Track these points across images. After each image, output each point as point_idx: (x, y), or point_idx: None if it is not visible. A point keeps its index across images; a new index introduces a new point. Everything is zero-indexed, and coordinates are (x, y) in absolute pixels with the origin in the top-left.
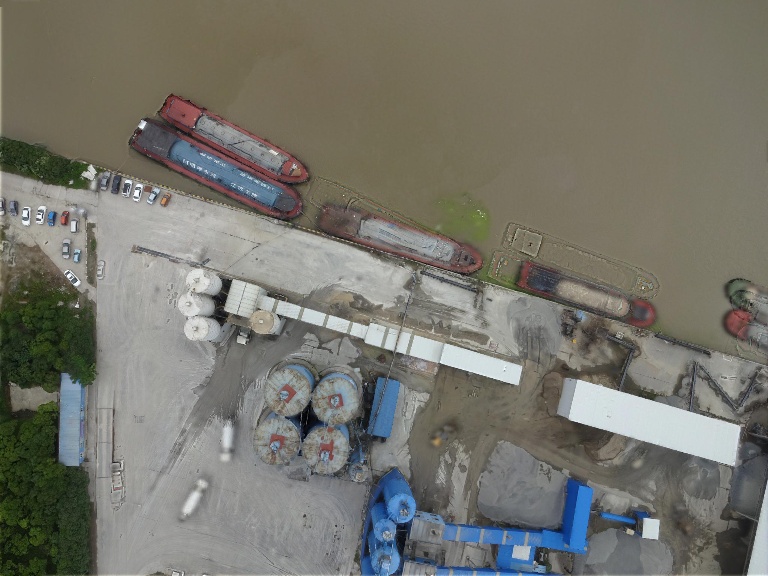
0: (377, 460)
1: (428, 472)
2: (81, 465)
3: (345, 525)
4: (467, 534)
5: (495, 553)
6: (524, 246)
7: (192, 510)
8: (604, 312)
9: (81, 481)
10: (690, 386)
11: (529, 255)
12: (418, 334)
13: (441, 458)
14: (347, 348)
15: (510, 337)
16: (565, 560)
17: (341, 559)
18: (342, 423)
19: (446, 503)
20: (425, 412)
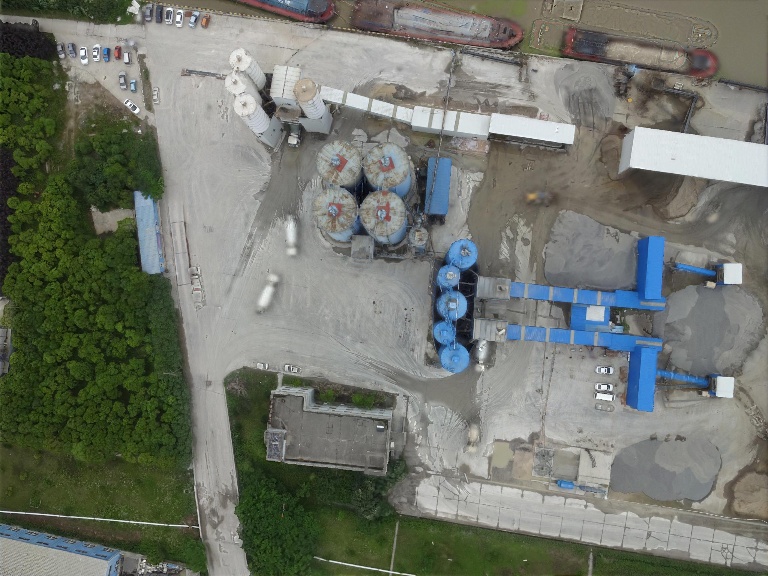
0: (438, 243)
1: (491, 249)
2: (163, 275)
3: (414, 308)
4: (535, 291)
5: (568, 321)
6: (565, 11)
7: (268, 307)
8: (659, 66)
9: (164, 286)
10: (763, 127)
11: (571, 20)
12: None
13: (502, 234)
14: (395, 138)
15: (560, 106)
16: (643, 322)
17: (414, 340)
18: (395, 186)
19: (512, 277)
20: (481, 191)
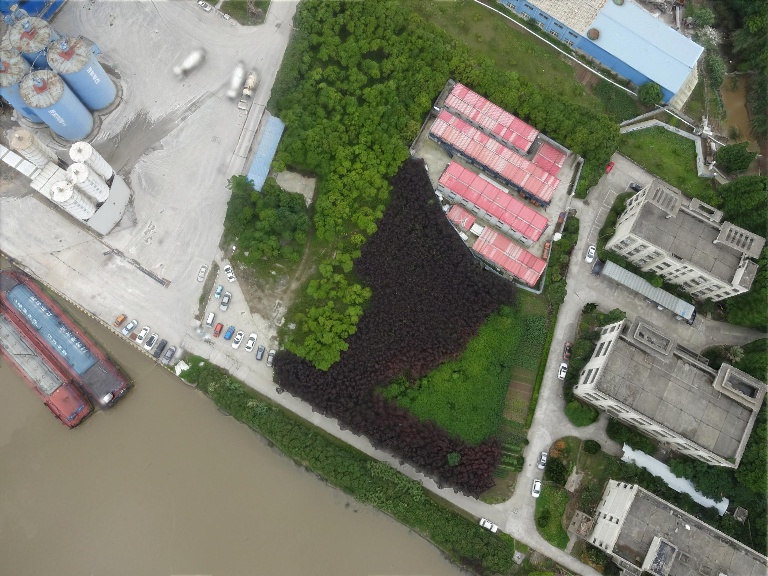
0: None
1: None
2: None
3: (82, 7)
4: None
5: None
6: None
7: (200, 59)
8: None
9: None
10: None
11: None
12: None
13: None
14: None
15: None
16: None
17: None
18: (7, 51)
19: None
20: None
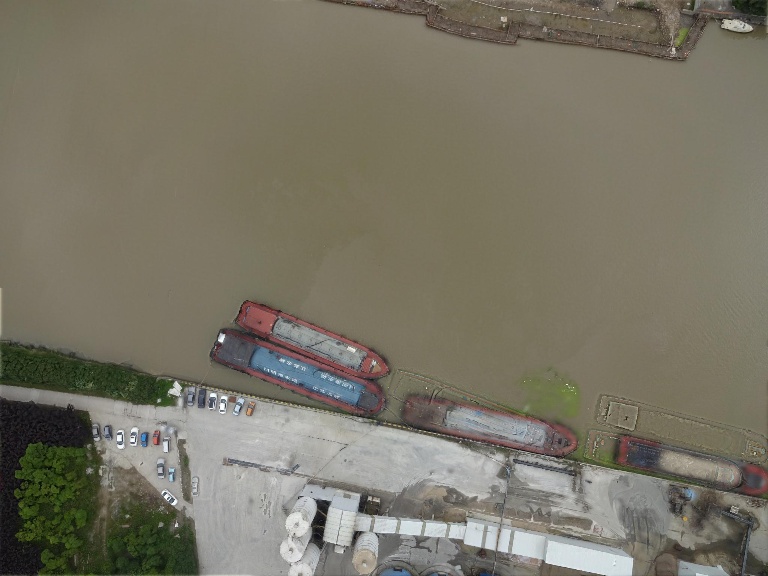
0: None
1: None
2: None
3: None
4: None
5: None
6: (620, 421)
7: None
8: (714, 484)
9: None
10: None
11: (626, 429)
12: (517, 524)
13: None
14: (445, 545)
15: (615, 519)
16: None
17: None
18: None
19: None
20: None
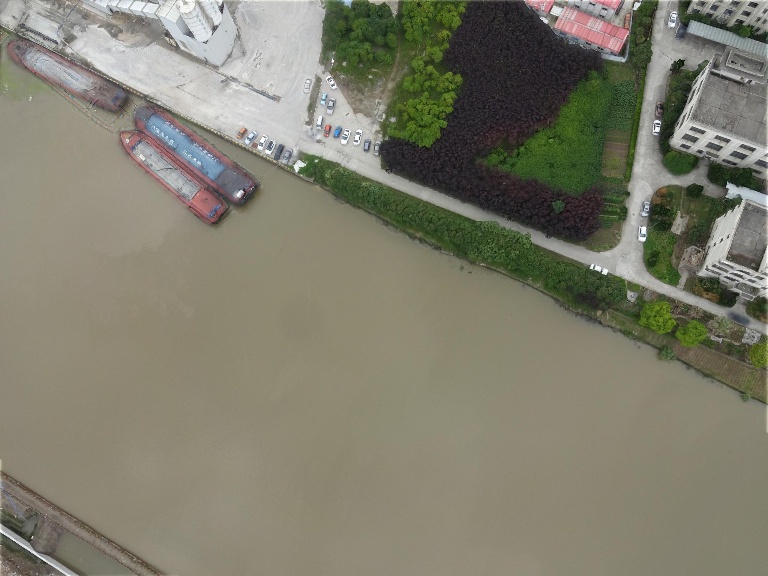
0: None
1: None
2: None
3: None
4: None
5: None
6: None
7: None
8: None
9: None
10: None
11: None
12: (79, 3)
13: None
14: None
15: None
16: None
17: None
18: None
19: None
20: None
